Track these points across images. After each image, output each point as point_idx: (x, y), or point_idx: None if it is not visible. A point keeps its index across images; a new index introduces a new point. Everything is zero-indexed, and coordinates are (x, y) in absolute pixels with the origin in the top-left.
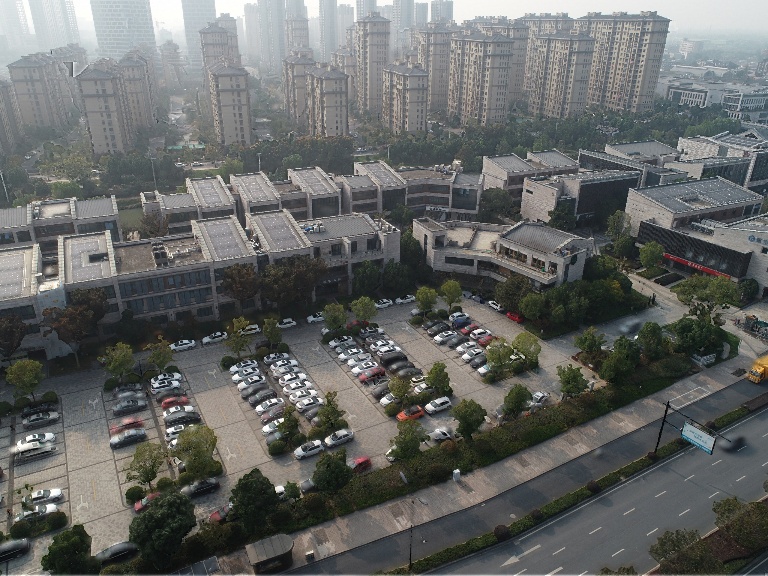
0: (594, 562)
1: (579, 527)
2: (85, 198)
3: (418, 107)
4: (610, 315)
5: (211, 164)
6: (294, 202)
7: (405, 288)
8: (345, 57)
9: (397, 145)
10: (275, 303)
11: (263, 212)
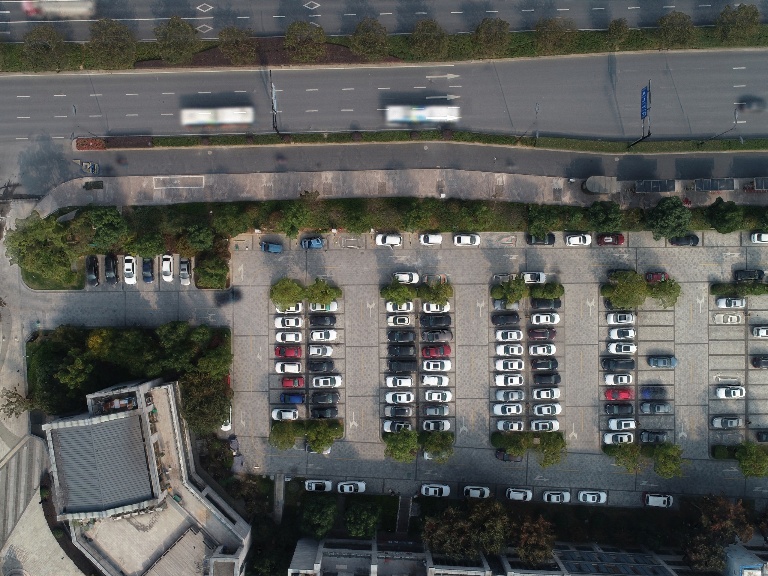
0: (405, 90)
1: (391, 117)
2: None
3: None
4: None
5: None
6: None
7: None
8: None
9: None
10: None
11: None
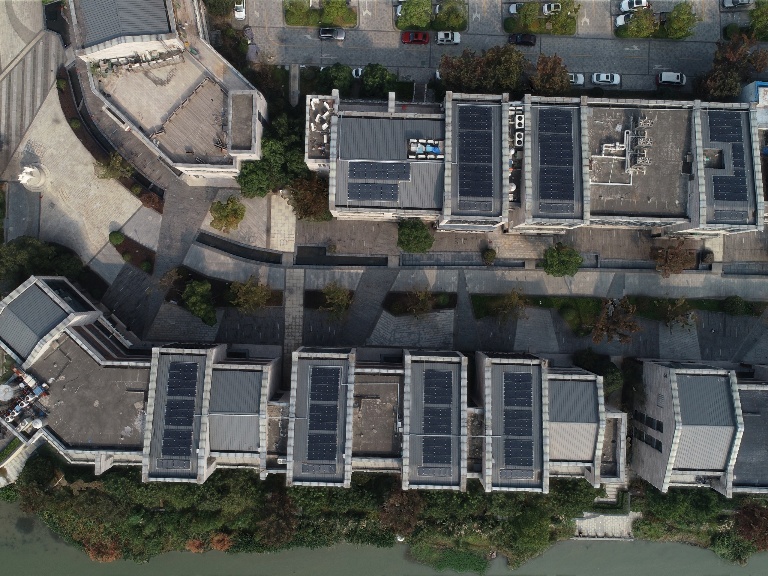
0: None
1: None
2: None
3: None
4: None
5: None
6: None
7: None
8: None
9: None
10: None
11: (481, 217)
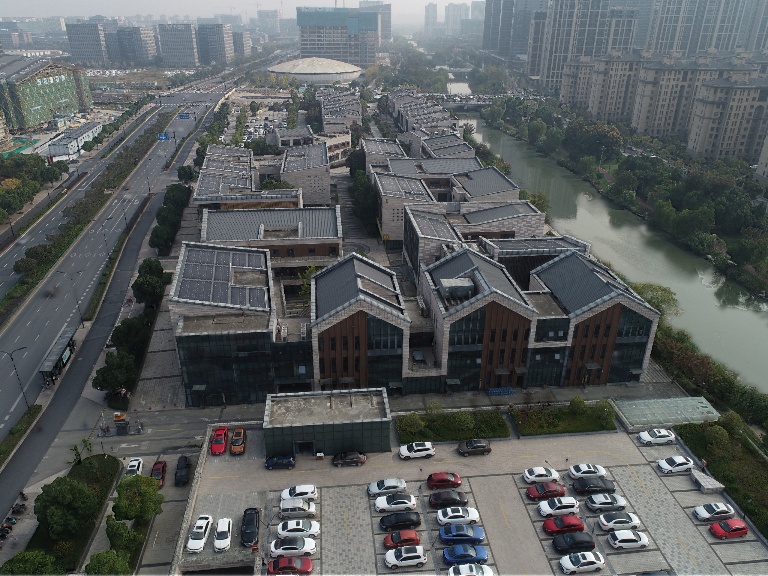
0: None
1: None
2: (511, 122)
3: None
4: None
5: None
6: None
7: None
8: None
9: (630, 156)
10: None
11: None
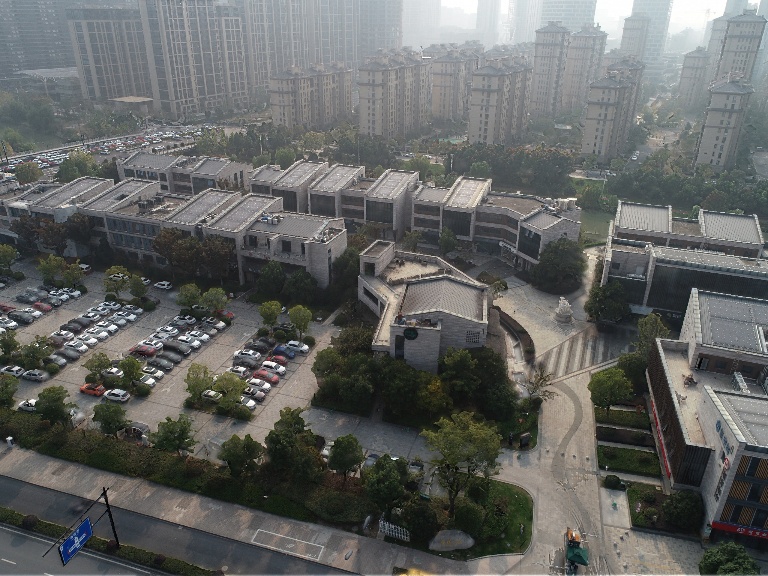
0: None
1: None
2: None
3: (719, 134)
4: (427, 424)
5: (440, 159)
6: (356, 199)
7: (318, 304)
8: (712, 65)
9: (630, 174)
10: (210, 273)
11: None
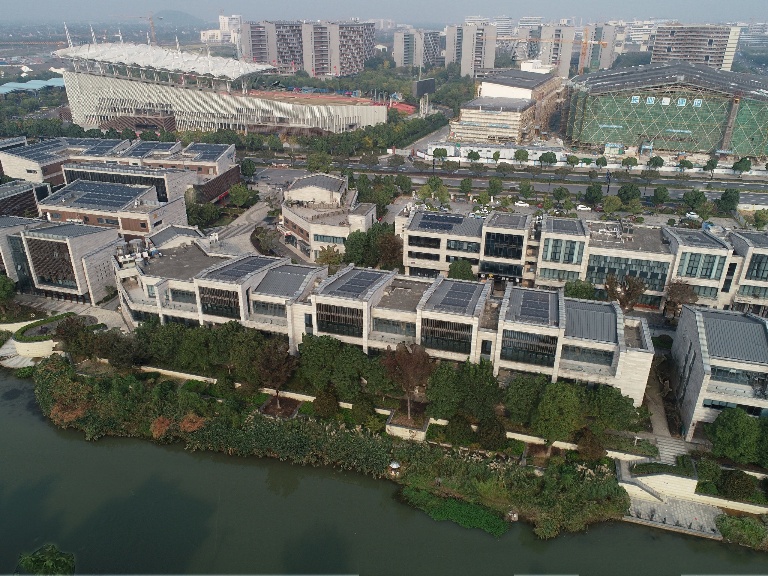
0: None
1: None
2: None
3: None
4: None
5: None
6: None
7: None
8: None
9: None
10: None
11: (509, 227)
